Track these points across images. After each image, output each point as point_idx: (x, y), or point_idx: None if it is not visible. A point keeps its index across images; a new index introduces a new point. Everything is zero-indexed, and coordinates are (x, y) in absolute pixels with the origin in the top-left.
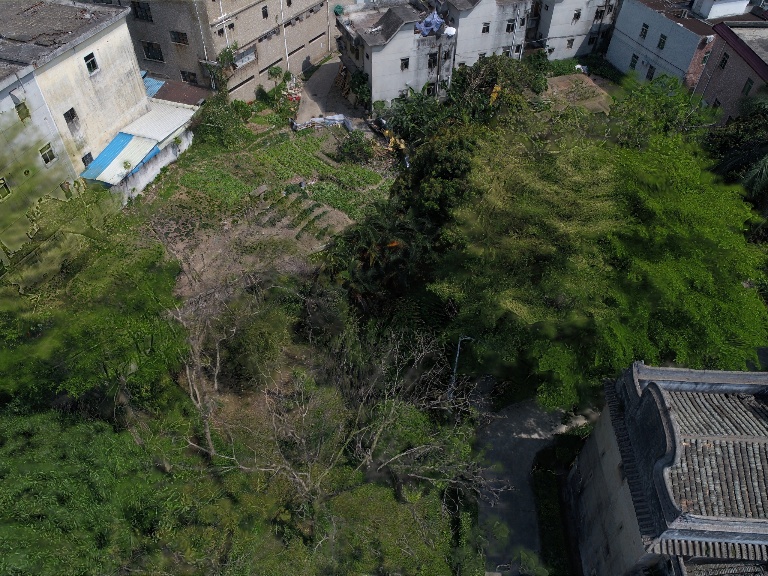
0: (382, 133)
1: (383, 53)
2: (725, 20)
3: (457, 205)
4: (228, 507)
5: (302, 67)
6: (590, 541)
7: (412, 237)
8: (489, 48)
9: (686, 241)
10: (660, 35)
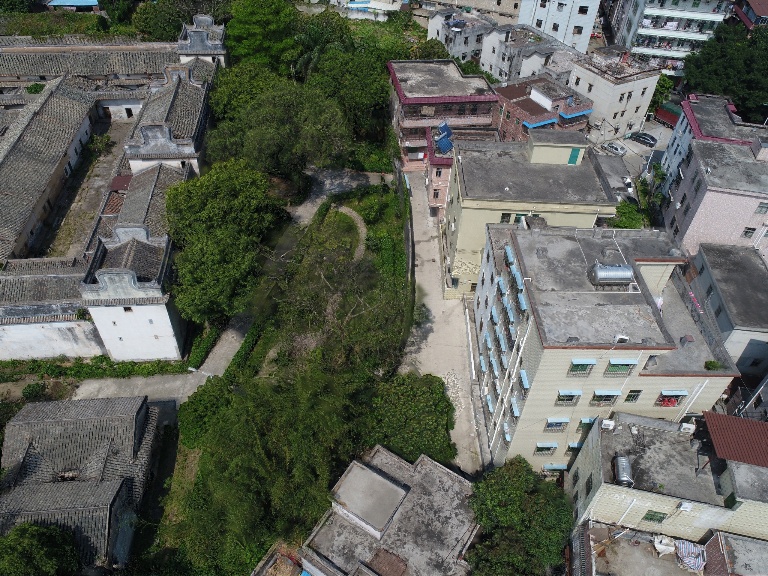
0: None
1: (432, 22)
2: (533, 104)
3: None
4: None
5: None
6: None
7: None
8: (494, 64)
9: None
10: None
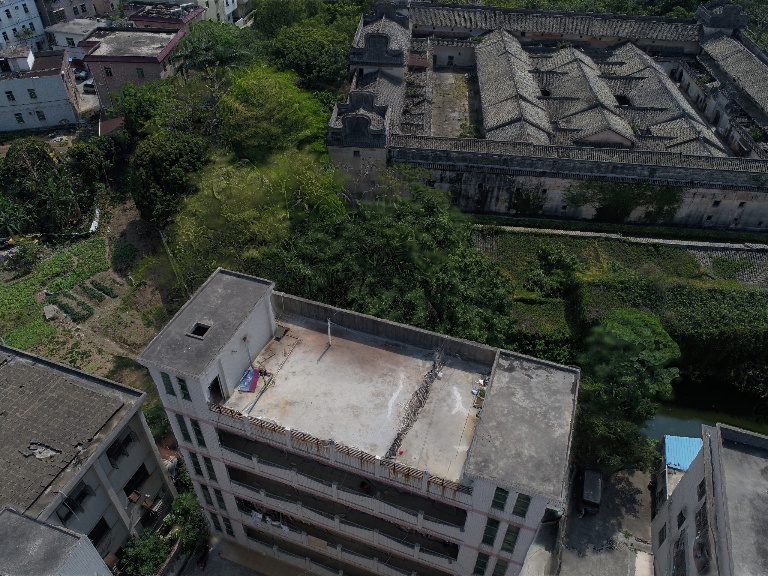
0: (9, 244)
1: None
2: (37, 66)
3: (194, 168)
4: (333, 303)
5: None
6: (364, 197)
7: (197, 199)
8: None
9: None
10: (27, 91)
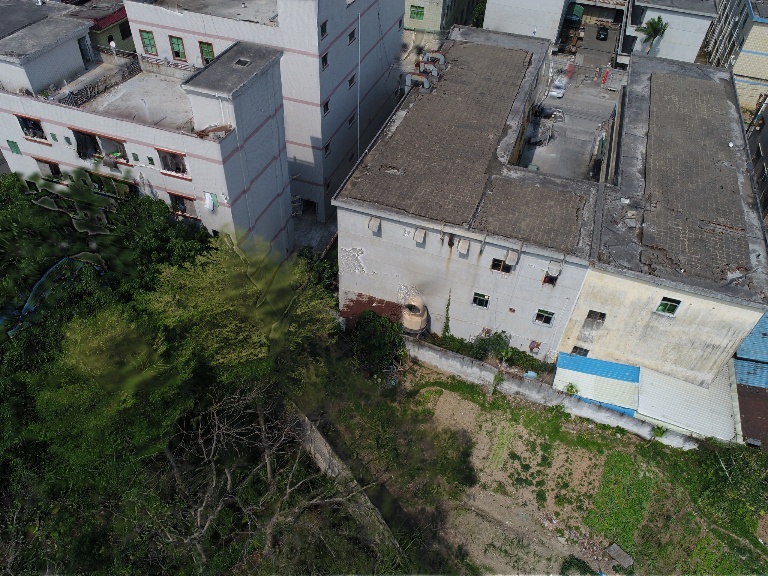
0: None
1: None
2: None
3: None
4: None
5: None
6: None
7: None
8: None
9: None
10: None
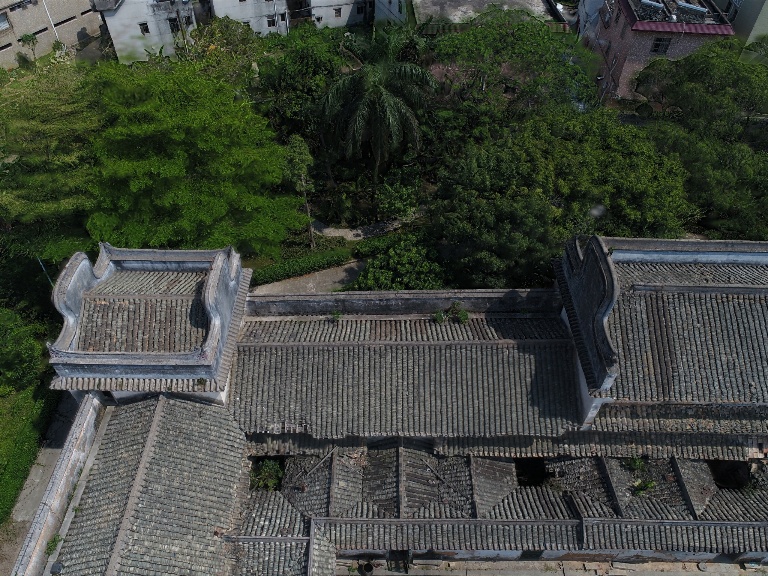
0: None
1: (117, 18)
2: None
3: None
4: None
5: (77, 38)
6: None
7: None
8: (251, 16)
9: (175, 145)
10: (398, 0)
